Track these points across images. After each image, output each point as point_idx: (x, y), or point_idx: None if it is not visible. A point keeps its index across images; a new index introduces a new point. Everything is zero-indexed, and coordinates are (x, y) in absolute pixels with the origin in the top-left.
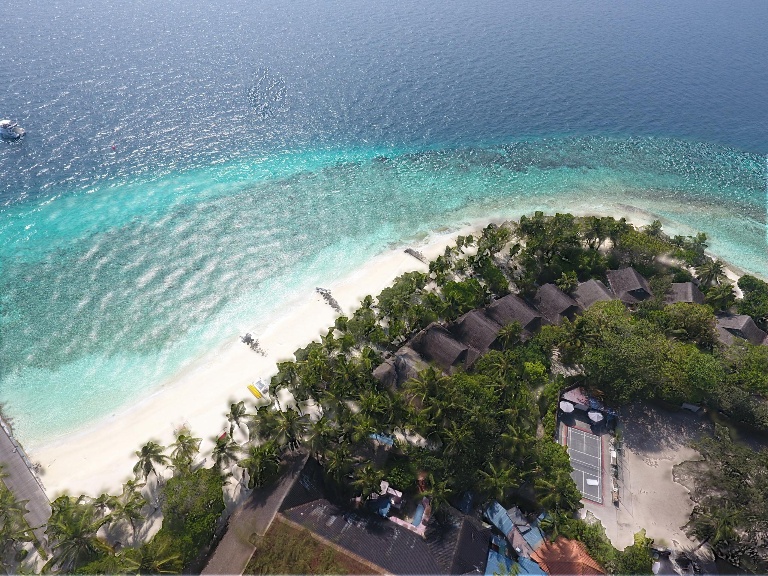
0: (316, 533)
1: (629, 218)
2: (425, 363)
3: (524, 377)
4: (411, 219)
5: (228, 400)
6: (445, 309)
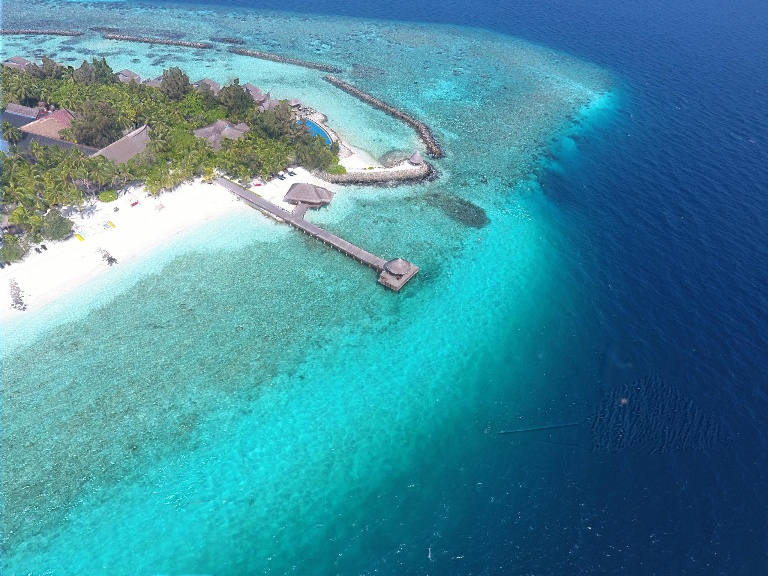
0: (84, 147)
1: None
2: None
3: None
4: None
5: (131, 222)
6: None
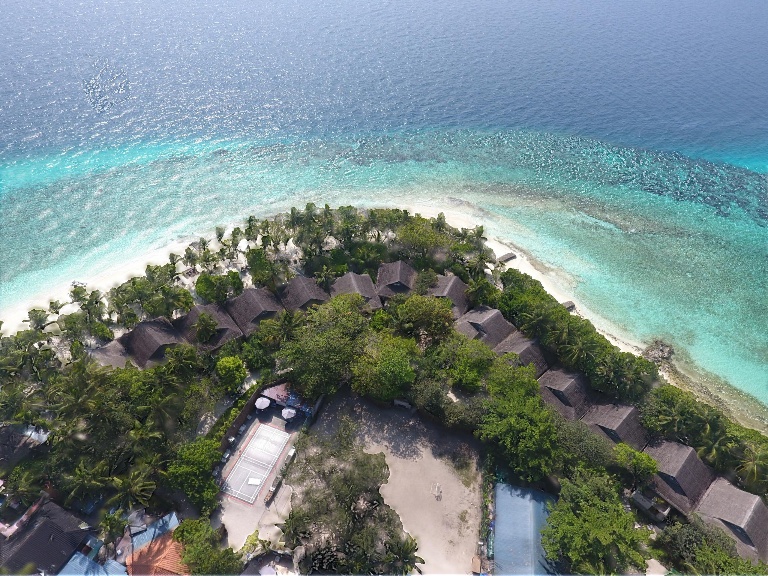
0: None
1: (452, 212)
2: (122, 357)
3: (214, 372)
4: (217, 212)
5: None
6: (161, 302)
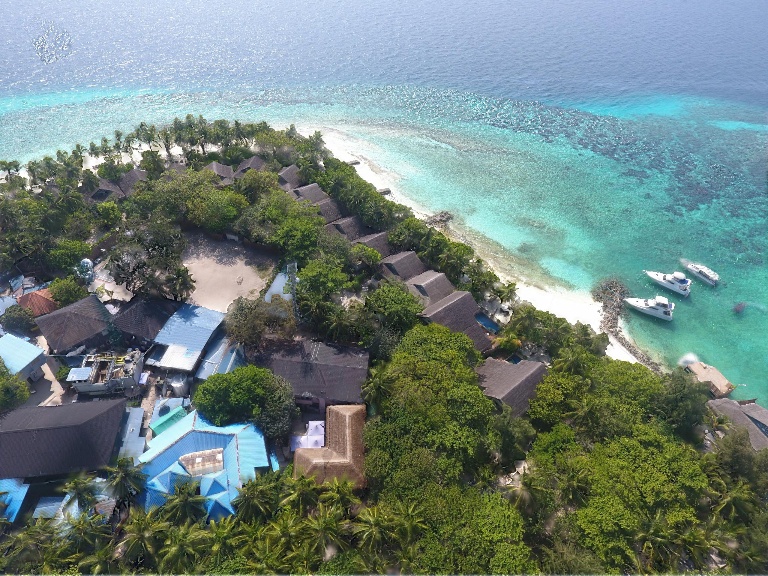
0: None
1: (322, 136)
2: None
3: (95, 210)
4: None
5: None
6: (64, 171)
